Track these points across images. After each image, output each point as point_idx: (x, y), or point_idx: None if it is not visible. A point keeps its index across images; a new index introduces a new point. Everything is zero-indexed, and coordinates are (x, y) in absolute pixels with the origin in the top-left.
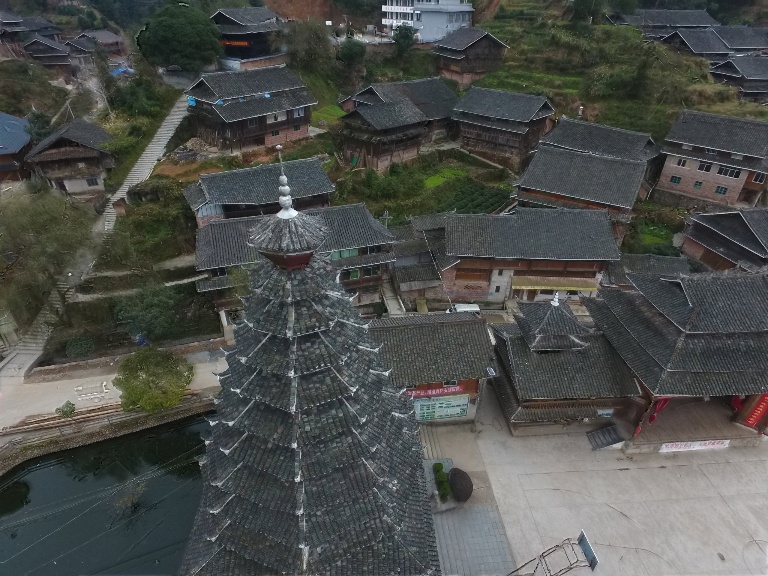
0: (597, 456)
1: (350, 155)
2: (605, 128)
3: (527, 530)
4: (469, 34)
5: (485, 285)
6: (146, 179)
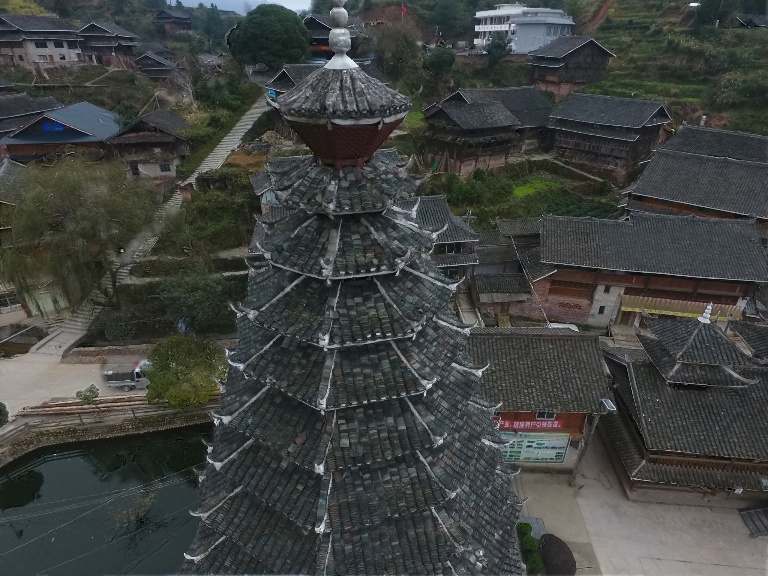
0: (759, 547)
1: (431, 159)
2: (739, 135)
3: None
4: (569, 42)
5: (586, 304)
6: (217, 168)
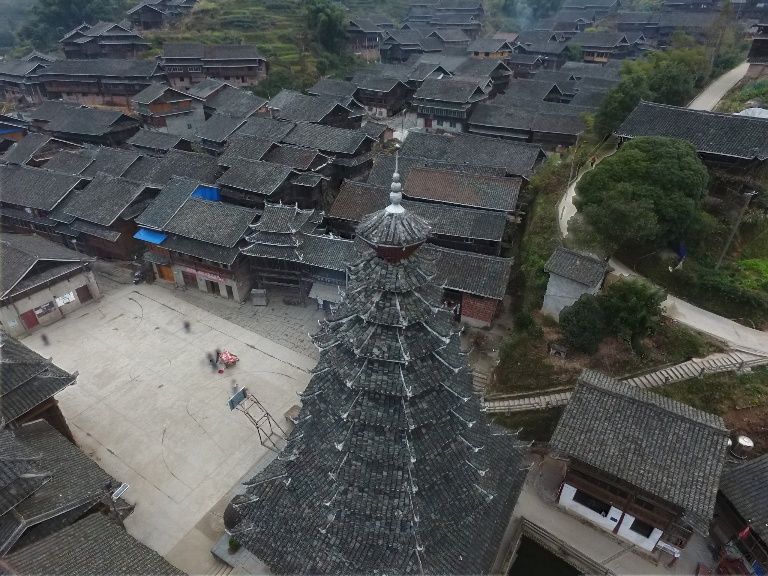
0: None
1: None
2: None
3: (231, 466)
4: None
5: None
6: None
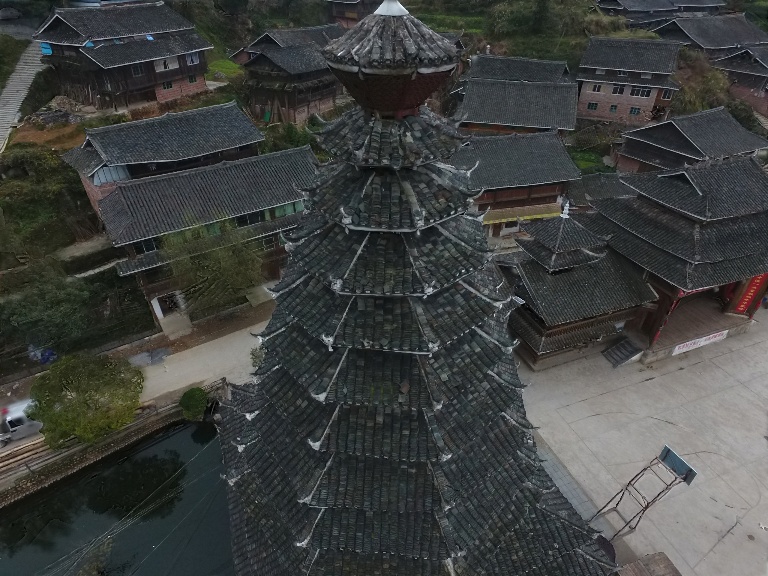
0: (621, 372)
1: (260, 110)
2: (521, 60)
3: (589, 464)
4: None
5: None
6: (1, 152)
